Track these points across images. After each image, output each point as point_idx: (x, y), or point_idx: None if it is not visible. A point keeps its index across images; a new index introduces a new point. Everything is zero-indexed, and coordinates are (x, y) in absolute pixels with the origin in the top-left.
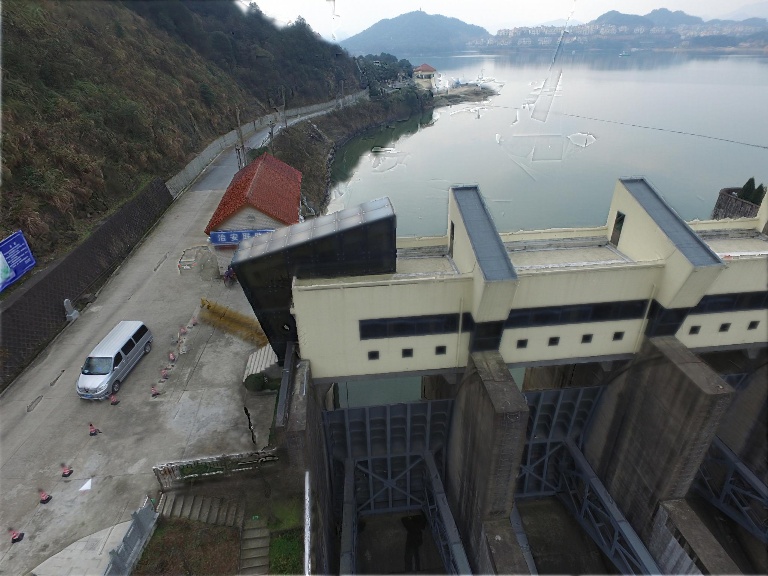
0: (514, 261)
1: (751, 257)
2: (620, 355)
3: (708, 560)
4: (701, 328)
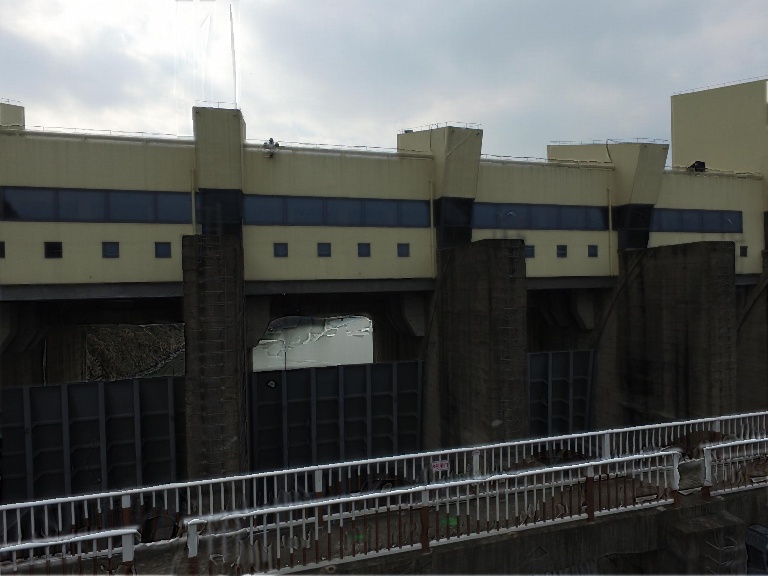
0: None
1: (318, 147)
2: (180, 287)
3: None
4: (289, 247)
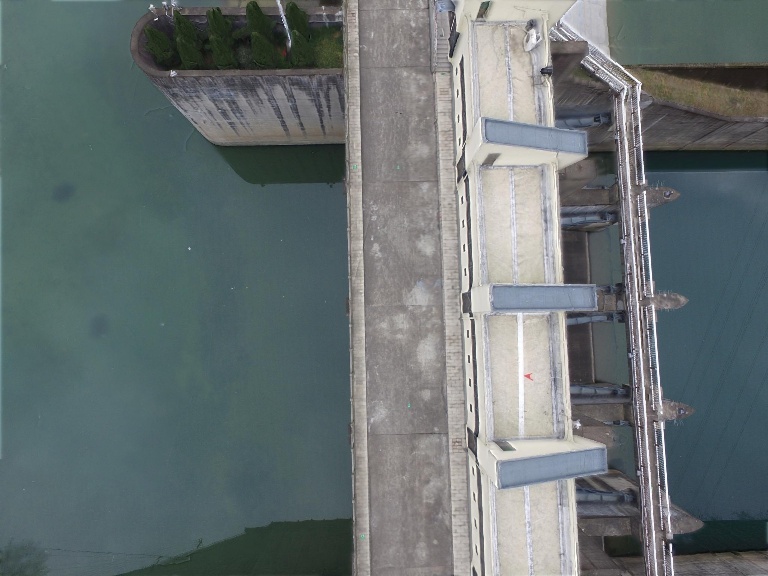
0: (519, 571)
1: None
2: None
3: (602, 418)
4: None
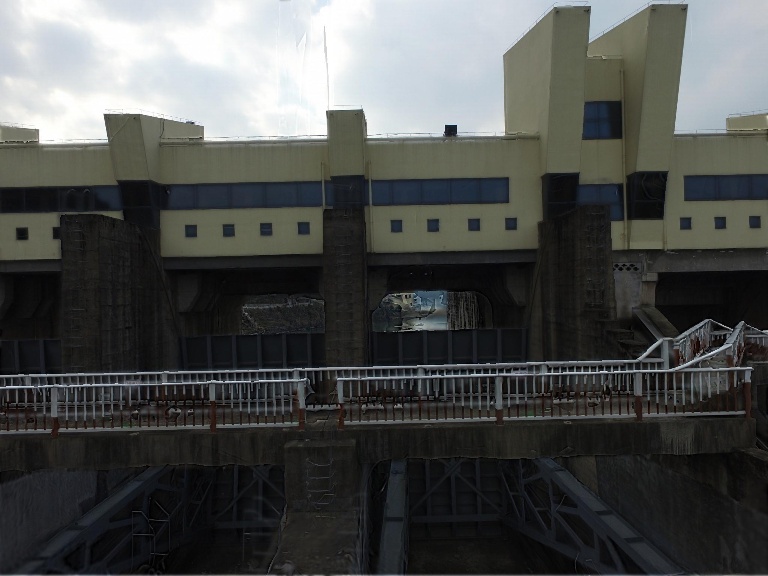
0: None
1: (18, 144)
2: None
3: None
4: None
